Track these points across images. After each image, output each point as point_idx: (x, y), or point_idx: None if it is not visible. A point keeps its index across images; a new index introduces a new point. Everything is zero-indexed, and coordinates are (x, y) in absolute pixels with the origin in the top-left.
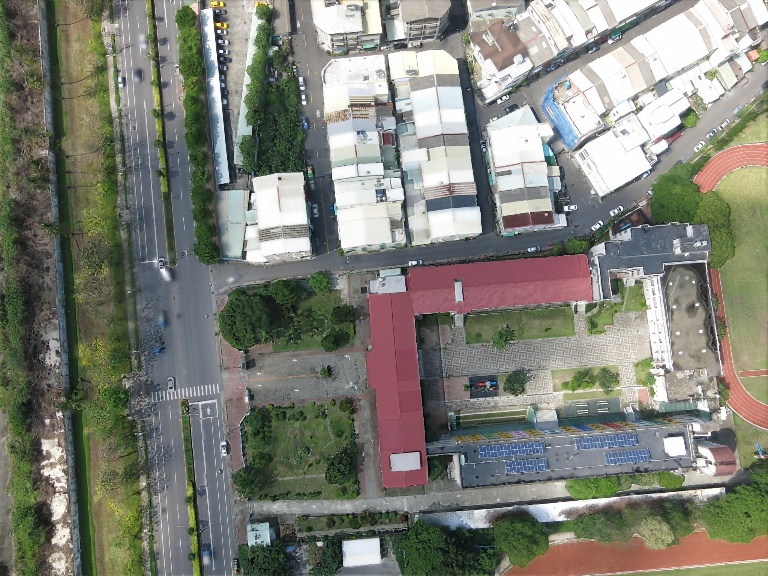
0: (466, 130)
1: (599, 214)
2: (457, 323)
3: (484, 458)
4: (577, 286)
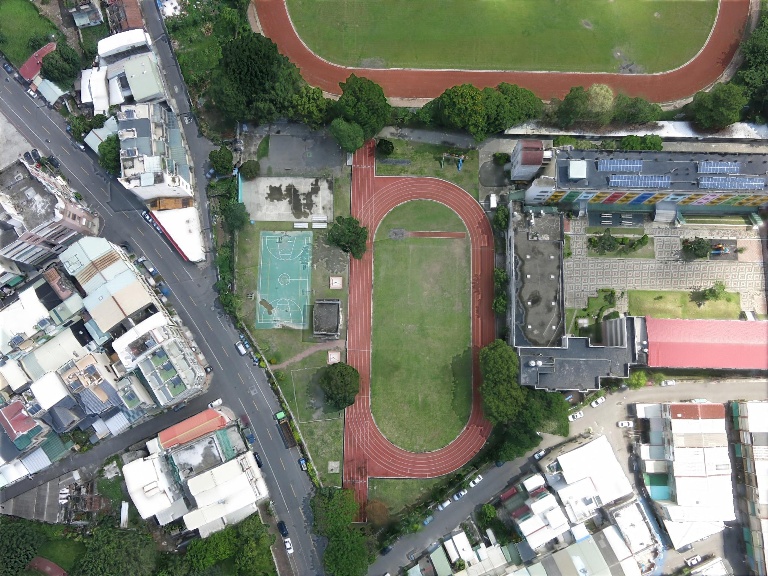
0: (763, 523)
1: (594, 415)
2: (749, 315)
3: (759, 178)
4: (662, 334)
